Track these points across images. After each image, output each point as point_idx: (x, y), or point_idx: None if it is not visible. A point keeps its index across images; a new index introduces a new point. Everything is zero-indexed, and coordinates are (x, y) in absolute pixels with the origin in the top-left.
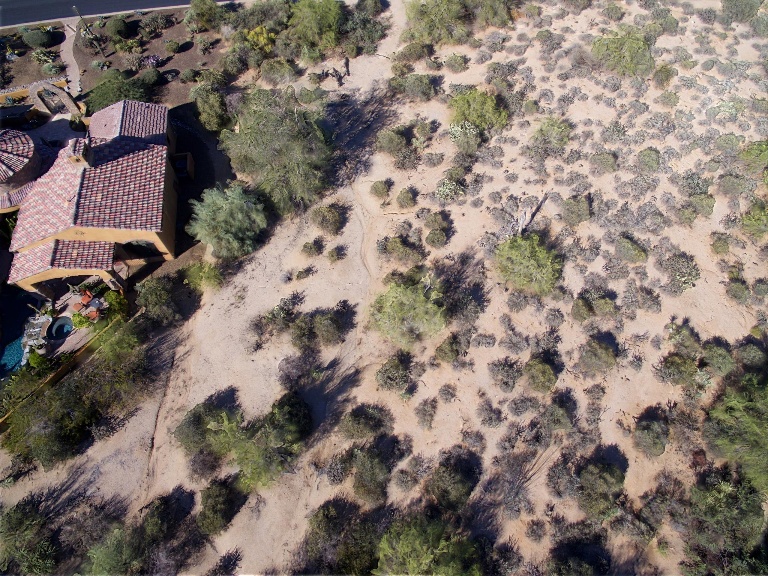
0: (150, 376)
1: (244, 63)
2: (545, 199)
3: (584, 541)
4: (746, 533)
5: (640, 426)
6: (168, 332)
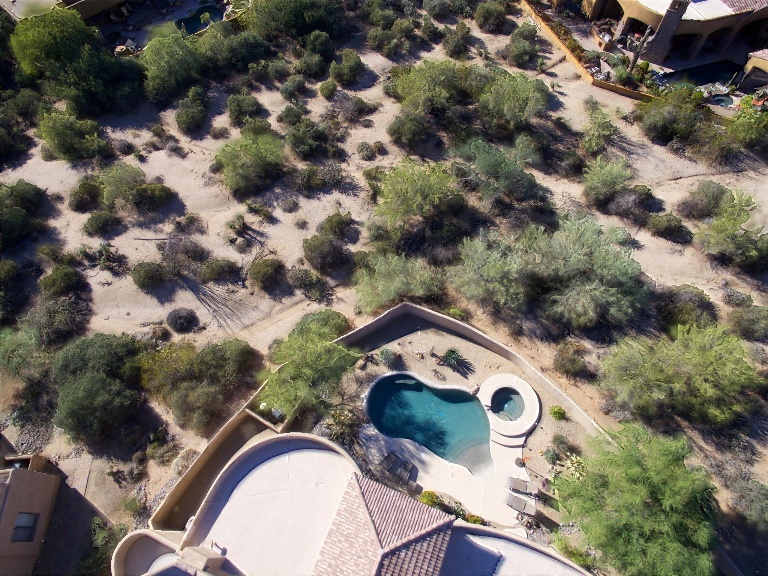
0: (723, 160)
1: None
2: None
3: None
4: None
5: None
6: (761, 160)
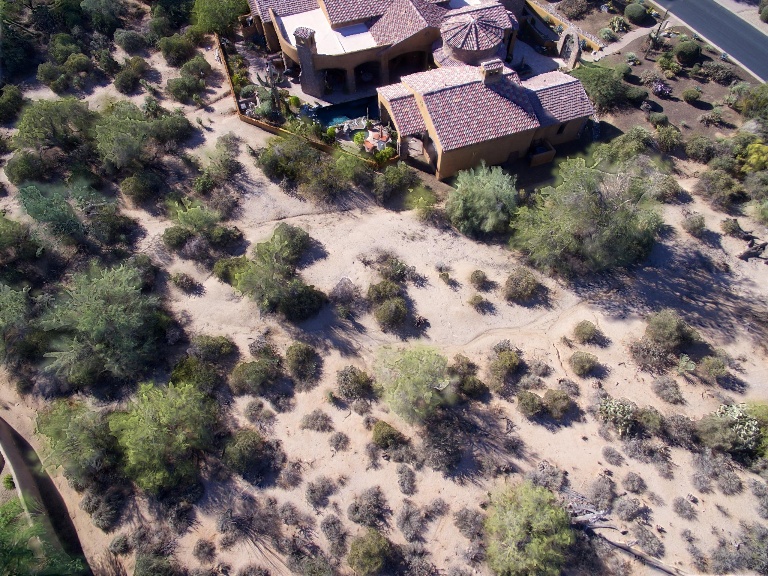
0: (331, 199)
1: (709, 155)
2: (666, 568)
3: None
4: None
5: None
6: (371, 198)
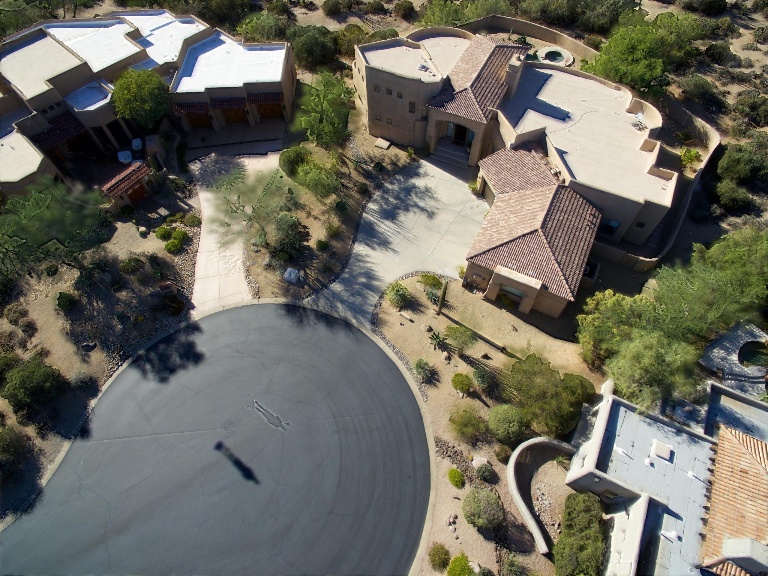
0: None
1: None
2: None
3: (721, 100)
4: None
5: None
6: None
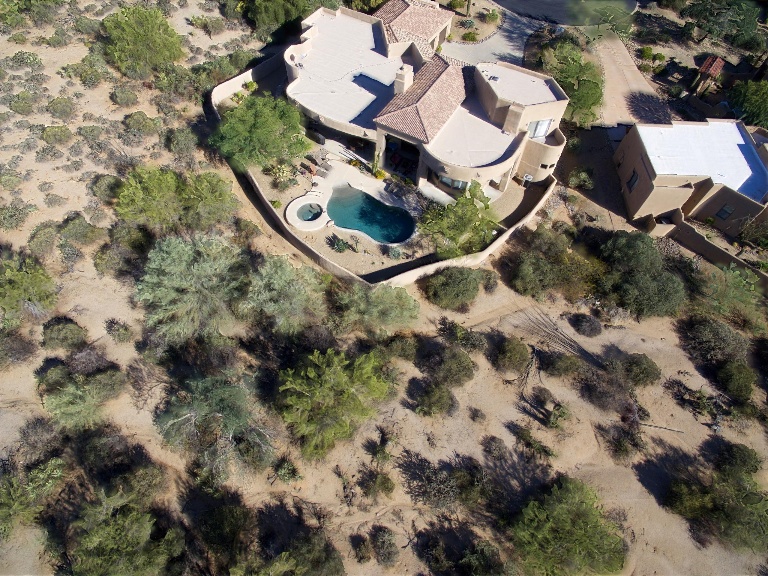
0: None
1: None
2: None
3: (168, 135)
4: (184, 73)
5: (116, 99)
6: None
